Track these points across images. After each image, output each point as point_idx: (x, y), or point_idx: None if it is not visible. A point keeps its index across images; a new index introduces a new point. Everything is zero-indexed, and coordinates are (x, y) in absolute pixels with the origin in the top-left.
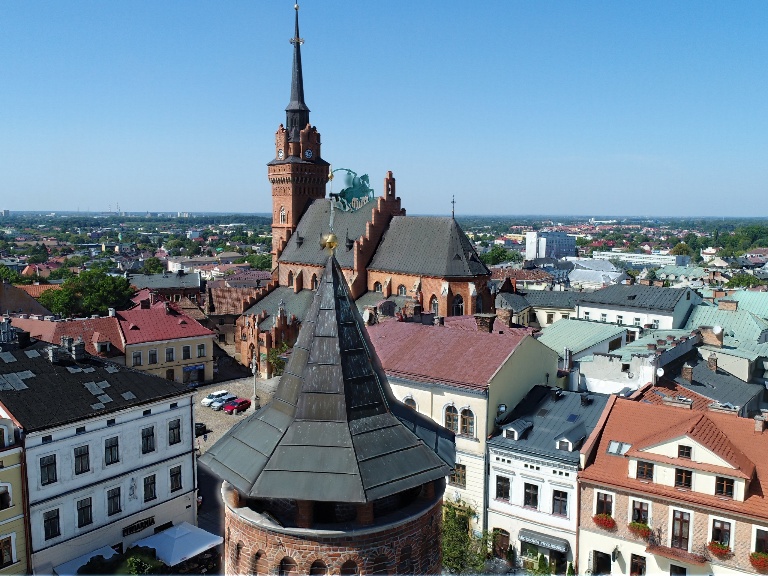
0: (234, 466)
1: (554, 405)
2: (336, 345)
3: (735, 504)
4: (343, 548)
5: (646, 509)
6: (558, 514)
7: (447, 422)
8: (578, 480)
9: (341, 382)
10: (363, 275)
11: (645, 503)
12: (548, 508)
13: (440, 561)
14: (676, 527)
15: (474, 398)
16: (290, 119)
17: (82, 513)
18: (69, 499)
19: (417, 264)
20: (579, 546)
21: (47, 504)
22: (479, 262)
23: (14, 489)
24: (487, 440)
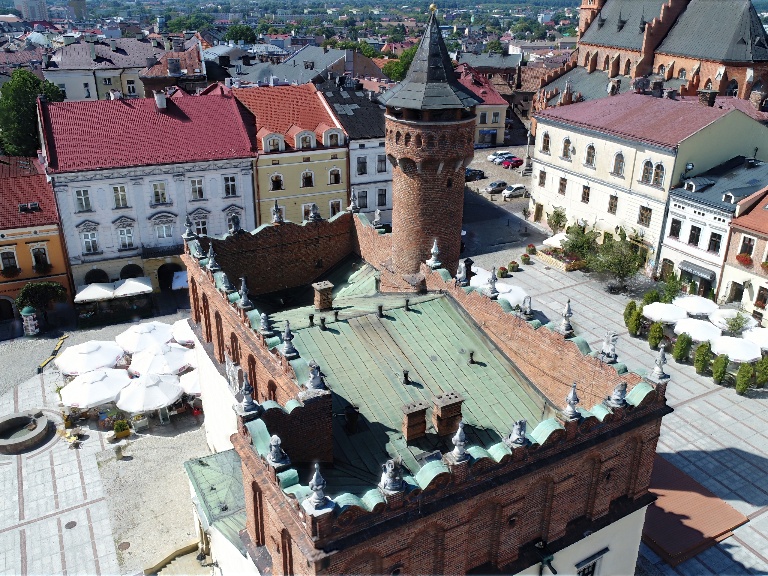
0: (385, 98)
1: (744, 171)
2: (428, 52)
3: None
4: (416, 129)
5: None
6: (712, 252)
7: (644, 174)
8: (731, 225)
9: (427, 68)
10: (650, 57)
11: None
12: (705, 246)
13: (465, 150)
14: None
15: (666, 155)
16: None
17: (380, 198)
18: (373, 187)
19: (701, 48)
20: (722, 277)
21: (360, 187)
22: (766, 47)
23: (343, 173)
24: (670, 190)
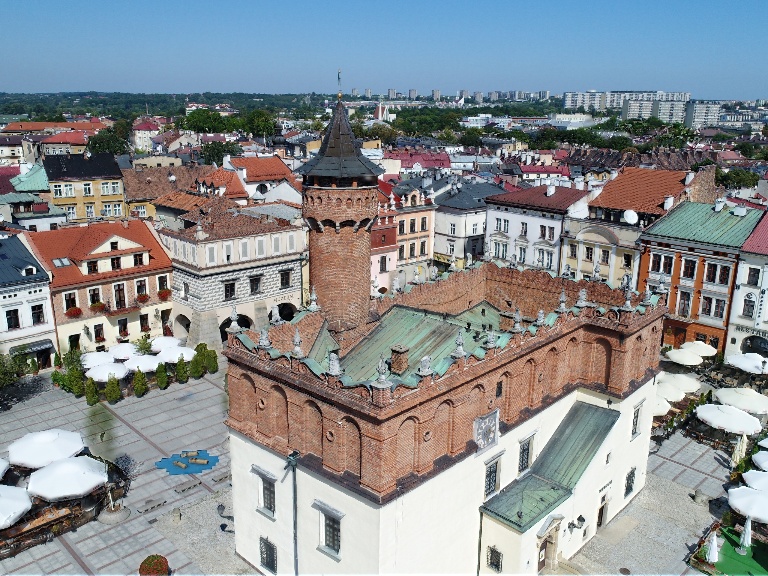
0: (359, 173)
1: None
2: None
3: (147, 267)
4: None
5: (98, 292)
6: (37, 324)
7: None
8: (51, 291)
9: None
10: None
11: (97, 288)
12: (30, 322)
13: None
14: (117, 296)
15: None
16: None
17: None
18: None
19: None
20: (59, 338)
21: None
22: None
23: None
24: None
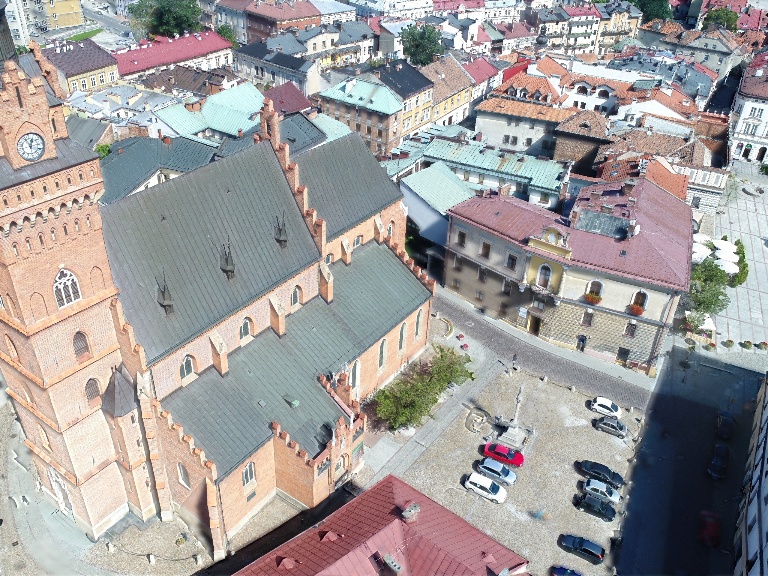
0: None
1: None
2: None
3: None
4: None
5: None
6: None
7: None
8: None
9: None
10: None
11: None
12: None
13: None
14: None
15: None
16: (1, 40)
17: None
18: None
19: (367, 202)
20: None
21: None
22: None
23: None
24: None
